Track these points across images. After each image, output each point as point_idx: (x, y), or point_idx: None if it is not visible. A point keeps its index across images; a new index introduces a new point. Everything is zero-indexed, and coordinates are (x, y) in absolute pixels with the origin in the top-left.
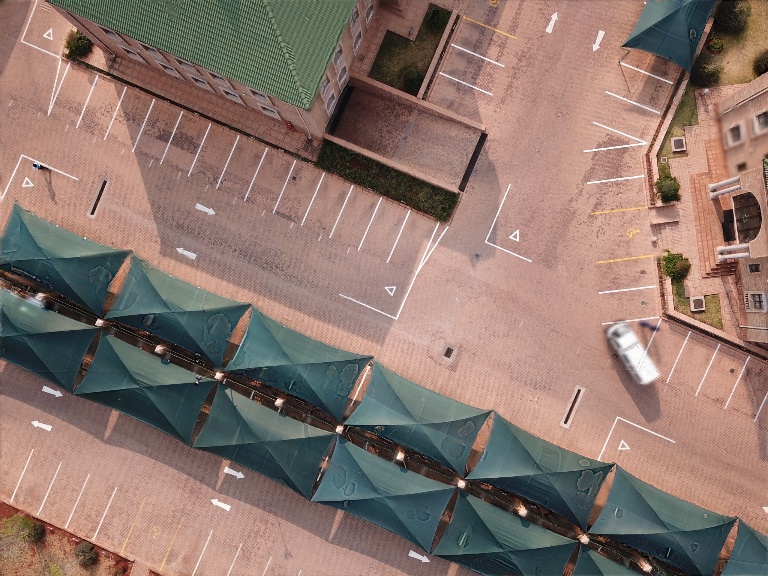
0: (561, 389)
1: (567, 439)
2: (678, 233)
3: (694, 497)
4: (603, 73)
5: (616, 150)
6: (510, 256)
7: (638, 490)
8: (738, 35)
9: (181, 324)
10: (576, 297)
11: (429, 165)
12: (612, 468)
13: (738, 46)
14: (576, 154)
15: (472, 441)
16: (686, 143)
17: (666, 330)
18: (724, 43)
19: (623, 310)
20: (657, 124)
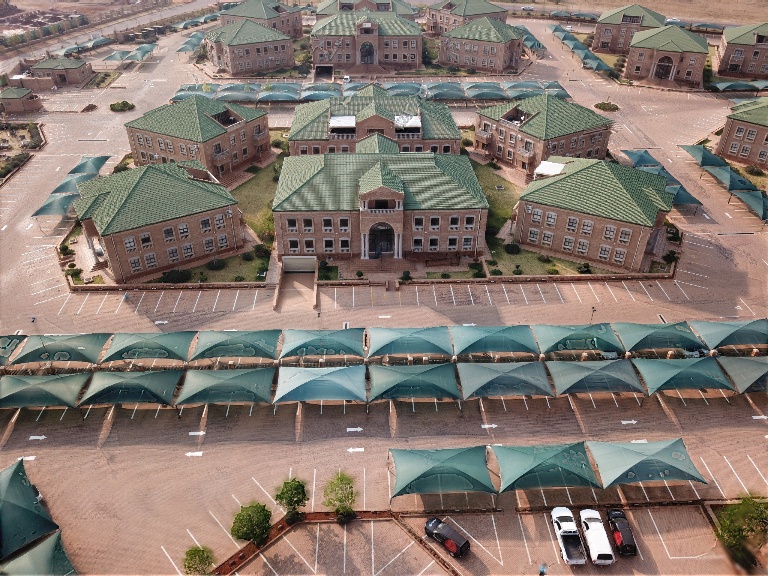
0: (5, 334)
1: (8, 351)
2: (75, 263)
3: None
4: None
5: None
6: None
7: None
8: None
9: None
10: (17, 300)
11: None
12: (26, 338)
13: None
14: (16, 257)
15: None
16: (77, 240)
17: (74, 296)
18: None
19: None
20: None
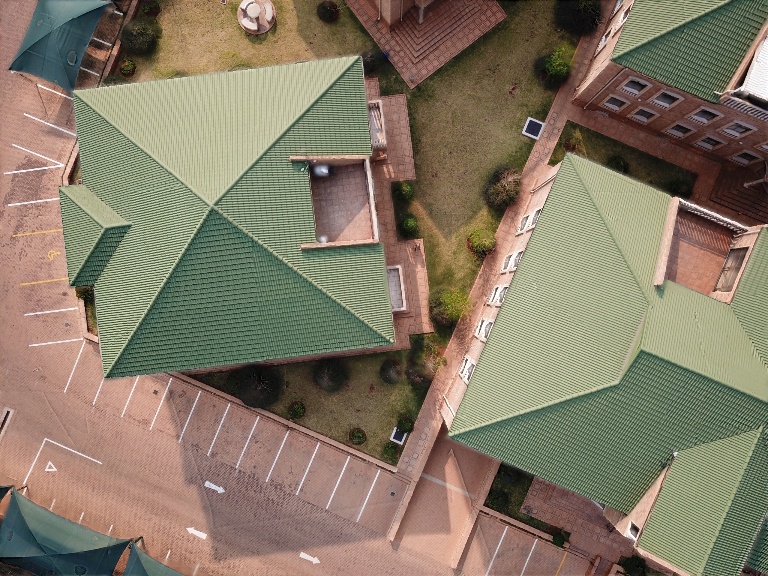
0: None
1: None
2: None
3: (119, 518)
4: (21, 95)
5: (35, 172)
6: None
7: (22, 513)
8: (150, 57)
9: None
10: (3, 319)
11: None
12: (9, 491)
13: (151, 68)
14: None
15: None
16: None
17: (91, 352)
18: (137, 65)
19: (48, 332)
20: (72, 146)
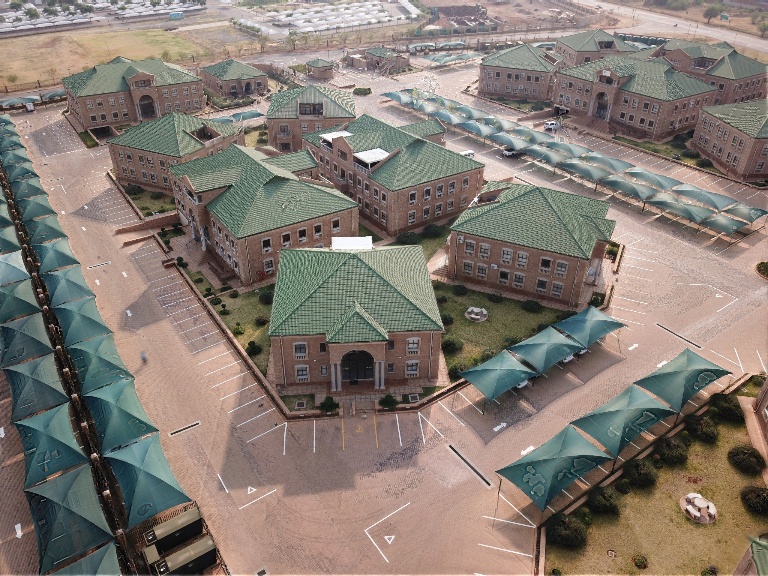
0: None
1: None
2: None
3: (49, 202)
4: None
5: None
6: (91, 156)
7: None
8: None
9: (0, 129)
10: None
11: (102, 142)
12: None
13: None
14: None
15: (17, 163)
16: None
17: None
18: None
19: None
20: None
